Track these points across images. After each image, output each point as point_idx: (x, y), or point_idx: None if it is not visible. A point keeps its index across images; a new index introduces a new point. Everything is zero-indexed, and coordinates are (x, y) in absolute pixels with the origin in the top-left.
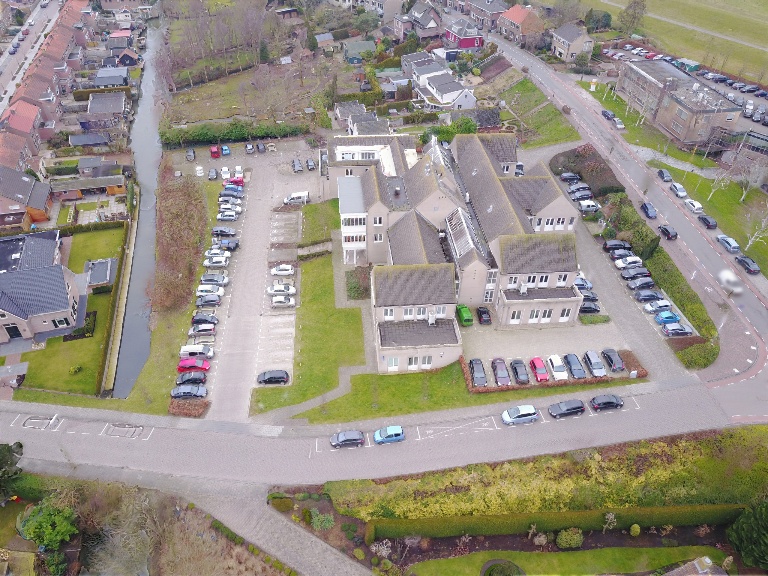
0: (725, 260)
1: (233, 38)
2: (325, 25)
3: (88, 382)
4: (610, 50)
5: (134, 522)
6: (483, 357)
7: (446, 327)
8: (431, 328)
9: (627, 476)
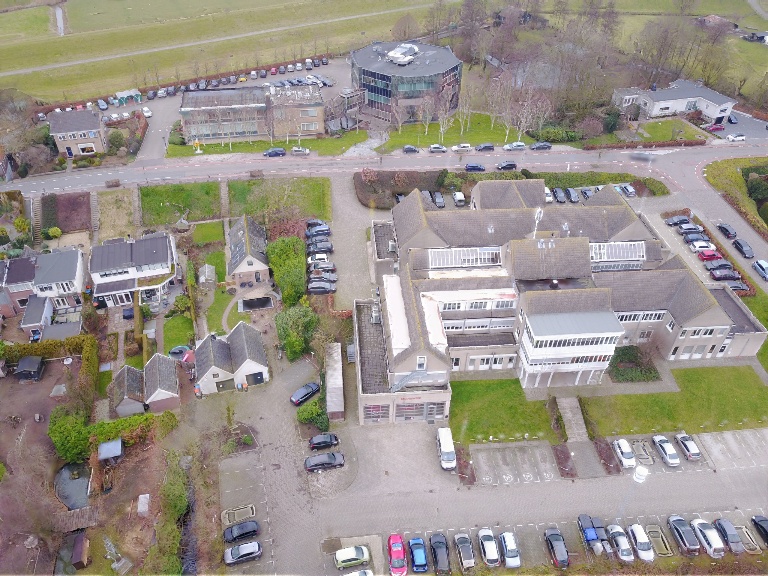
0: (535, 154)
1: None
2: None
3: None
4: None
5: None
6: None
7: None
8: None
9: None
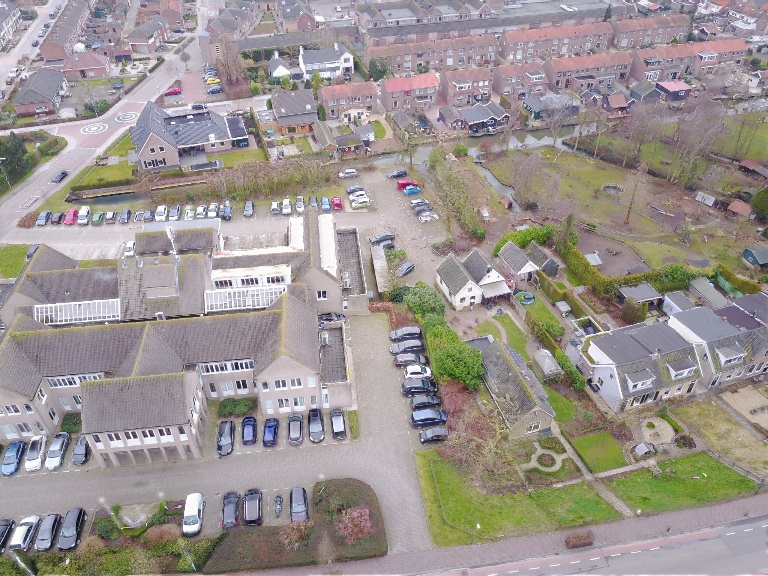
0: None
1: (765, 153)
2: None
3: None
4: None
5: None
6: None
7: None
8: None
9: None
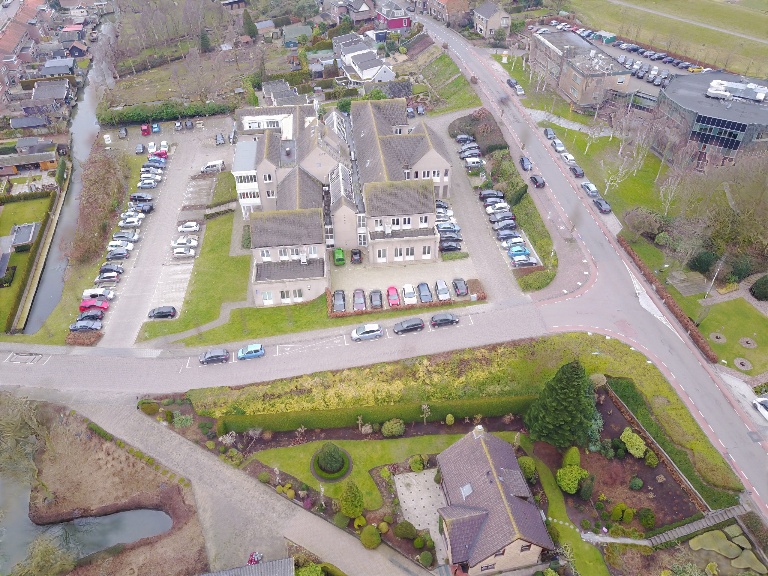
0: (584, 203)
1: (181, 29)
2: (268, 13)
3: (1, 322)
4: (535, 26)
5: (25, 428)
6: (348, 289)
7: (316, 265)
8: (303, 266)
9: (450, 378)
